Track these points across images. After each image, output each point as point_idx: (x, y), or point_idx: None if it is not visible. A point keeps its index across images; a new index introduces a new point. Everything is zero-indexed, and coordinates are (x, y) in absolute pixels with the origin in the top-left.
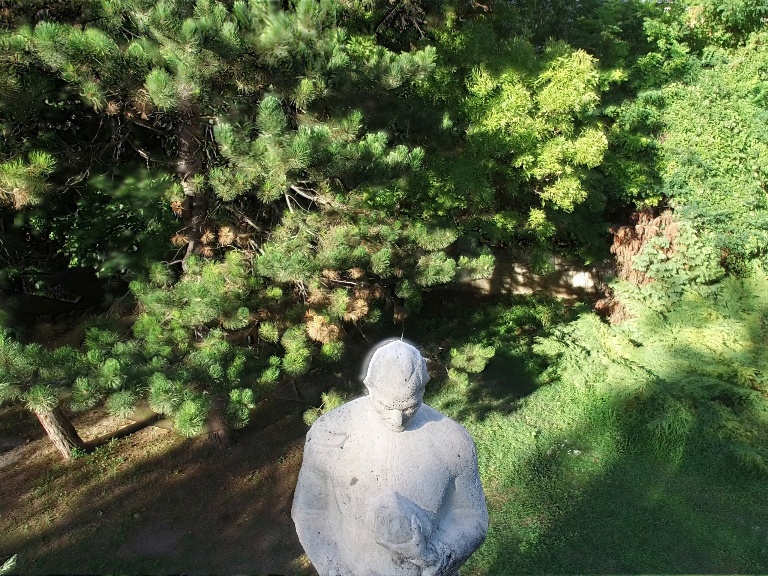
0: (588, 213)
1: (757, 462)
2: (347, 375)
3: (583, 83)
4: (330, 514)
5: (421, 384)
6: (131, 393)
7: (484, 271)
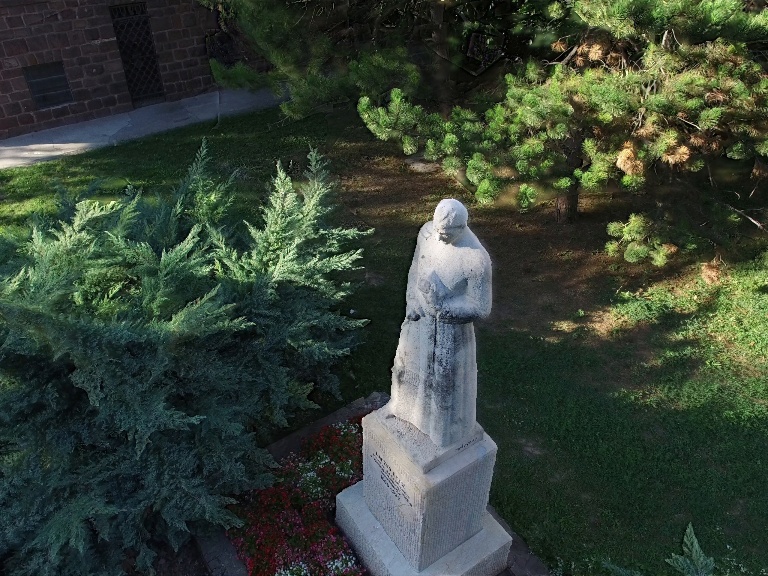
0: None
1: None
2: (665, 207)
3: None
4: None
5: (451, 225)
6: (460, 160)
7: None
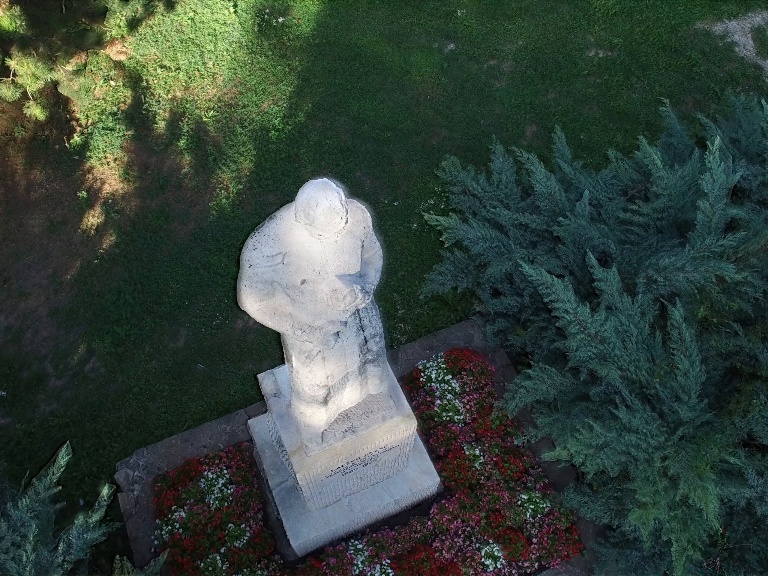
0: None
1: None
2: None
3: None
4: (277, 298)
5: None
6: None
7: None
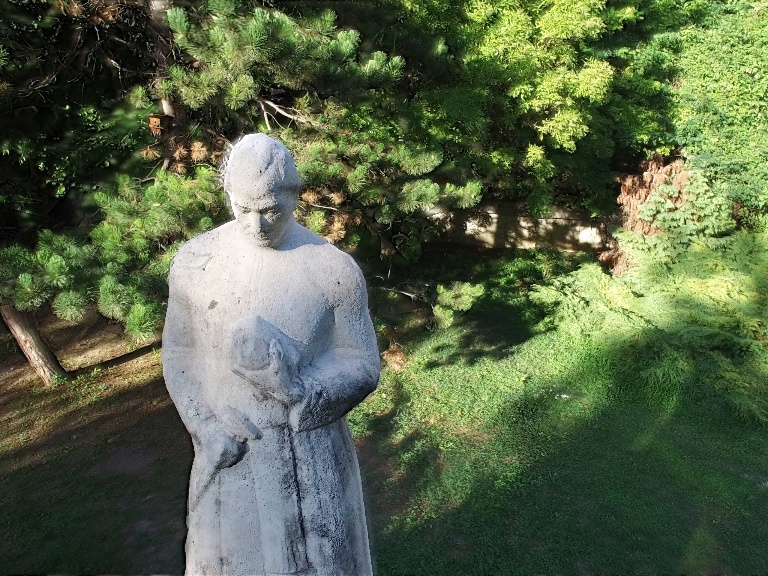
0: (596, 161)
1: (752, 412)
2: None
3: (589, 7)
4: (197, 353)
5: (282, 182)
6: (80, 296)
7: (471, 200)
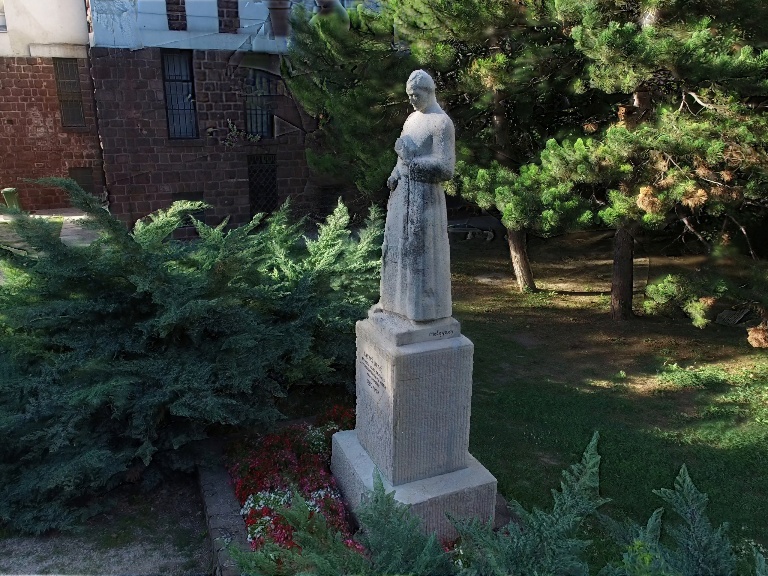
0: None
1: None
2: (703, 271)
3: None
4: None
5: (417, 85)
6: (491, 196)
7: None
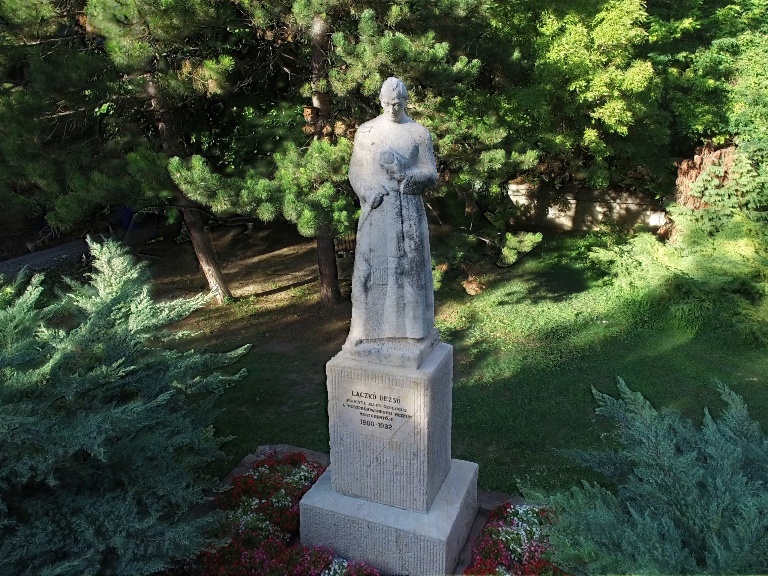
0: (657, 149)
1: (756, 335)
2: None
3: (631, 20)
4: (364, 169)
5: (402, 94)
6: (273, 206)
7: (530, 163)
